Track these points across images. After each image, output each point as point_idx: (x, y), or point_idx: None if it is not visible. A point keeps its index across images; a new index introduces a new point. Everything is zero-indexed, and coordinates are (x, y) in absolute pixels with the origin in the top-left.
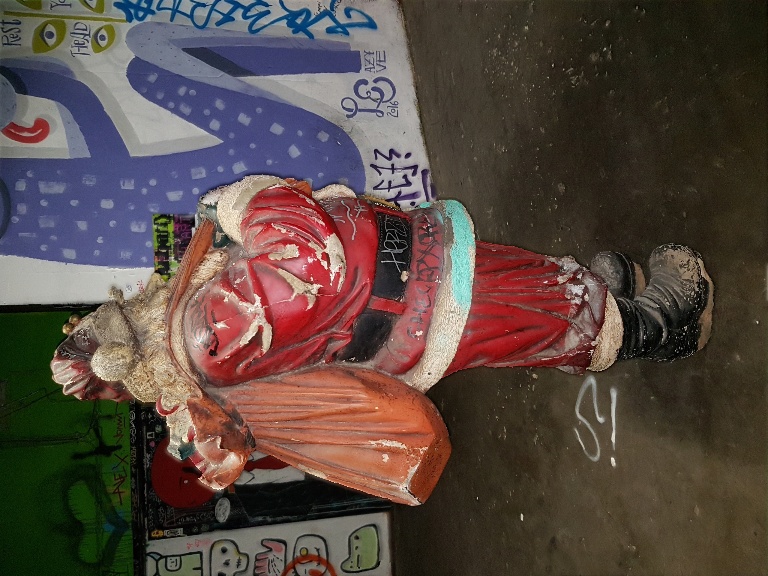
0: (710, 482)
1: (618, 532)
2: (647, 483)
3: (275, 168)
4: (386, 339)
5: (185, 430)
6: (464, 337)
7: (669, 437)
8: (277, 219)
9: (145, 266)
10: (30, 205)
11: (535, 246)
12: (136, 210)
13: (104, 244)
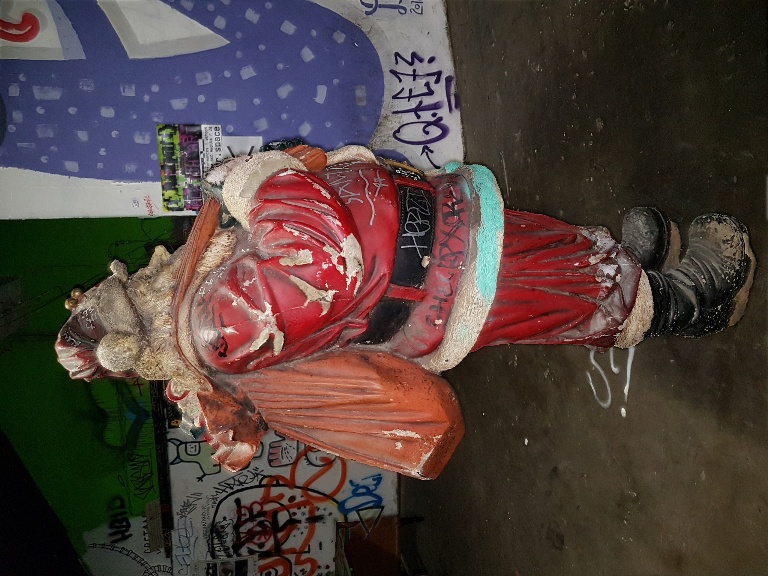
0: (721, 453)
1: (621, 477)
2: (656, 440)
3: (286, 73)
4: (403, 323)
5: (196, 414)
6: (485, 324)
7: (684, 402)
8: (289, 216)
9: (151, 180)
10: (26, 112)
11: (564, 181)
12: (139, 119)
13: (107, 156)
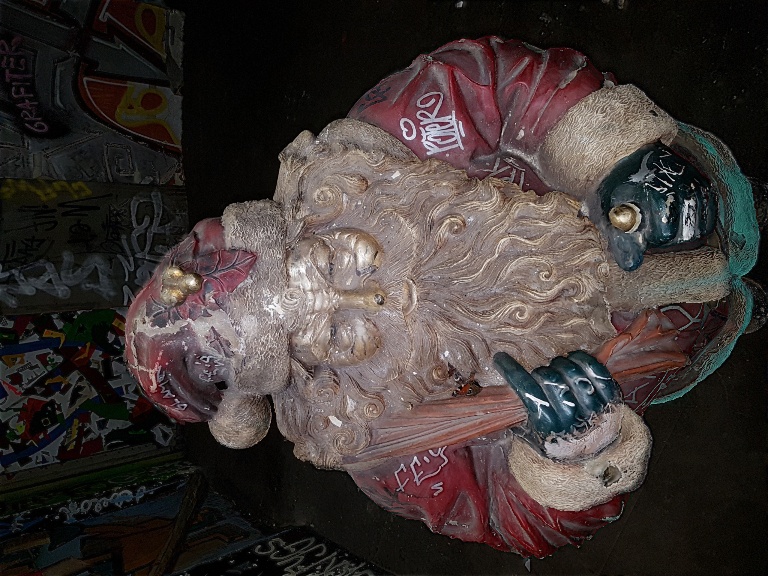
0: None
1: None
2: None
3: None
4: None
5: None
6: None
7: None
8: None
9: None
10: None
11: None
12: None
13: None
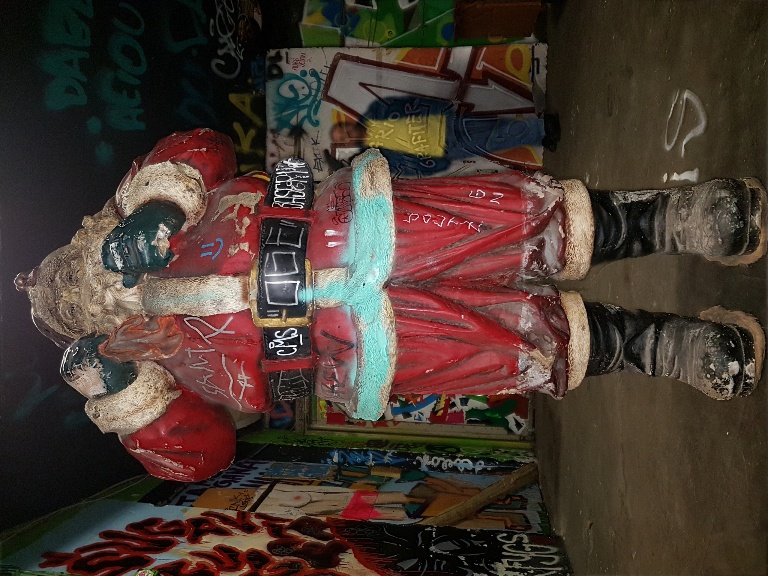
0: None
1: (641, 189)
2: None
3: None
4: None
5: None
6: None
7: (678, 275)
8: None
9: None
10: None
11: None
12: None
13: None
